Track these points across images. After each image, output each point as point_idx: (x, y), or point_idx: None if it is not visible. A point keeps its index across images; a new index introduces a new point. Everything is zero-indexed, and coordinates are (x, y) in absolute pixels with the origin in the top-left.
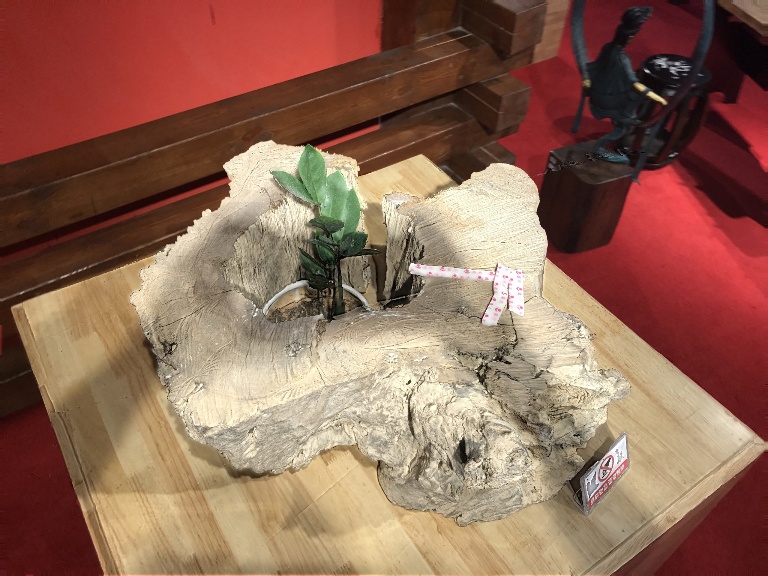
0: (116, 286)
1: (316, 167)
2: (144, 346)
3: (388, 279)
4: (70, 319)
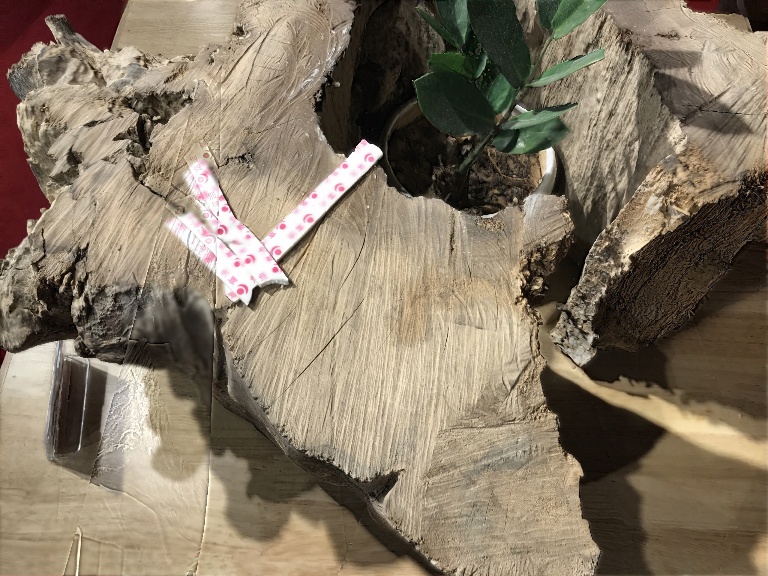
0: None
1: None
2: None
3: None
4: None
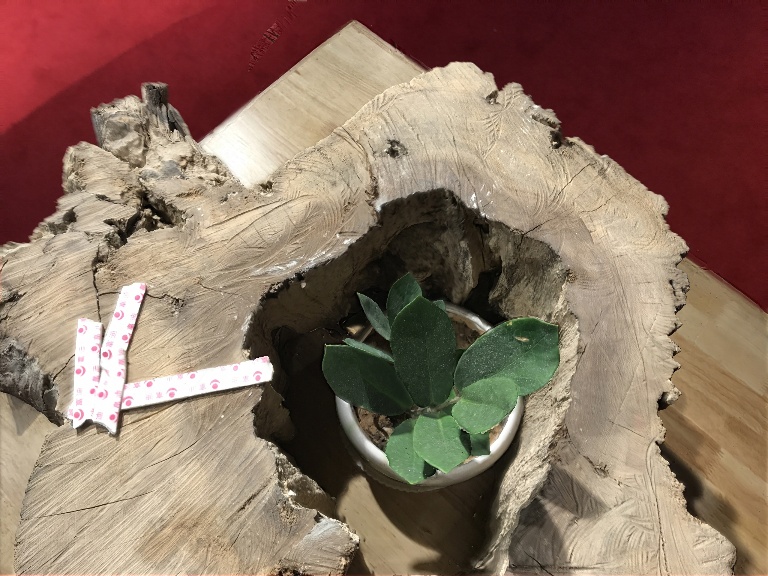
0: None
1: None
2: (679, 389)
3: None
4: None
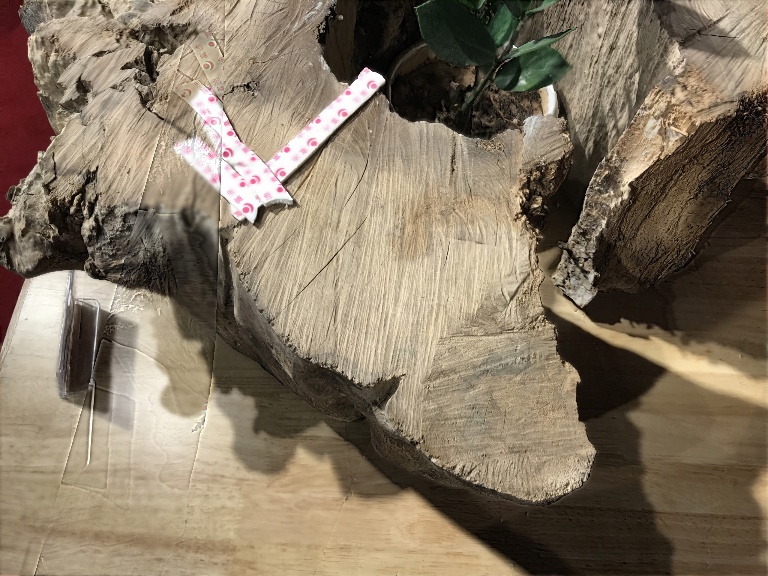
0: None
1: None
2: None
3: None
4: None
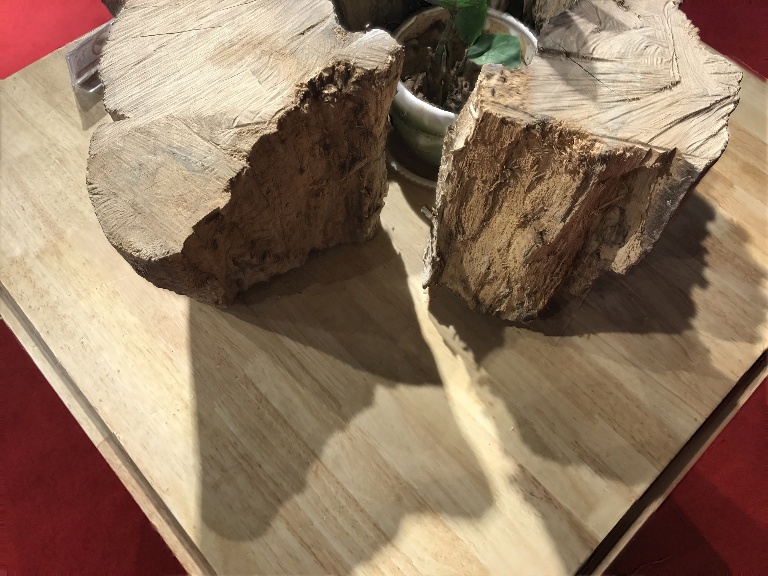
0: None
1: None
2: None
3: None
4: None
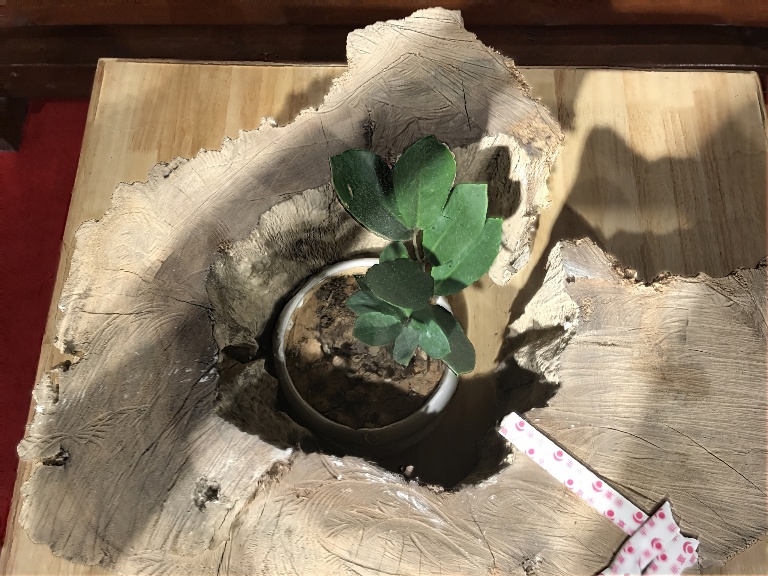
0: (214, 93)
1: (435, 173)
2: None
3: (521, 321)
4: (142, 115)
